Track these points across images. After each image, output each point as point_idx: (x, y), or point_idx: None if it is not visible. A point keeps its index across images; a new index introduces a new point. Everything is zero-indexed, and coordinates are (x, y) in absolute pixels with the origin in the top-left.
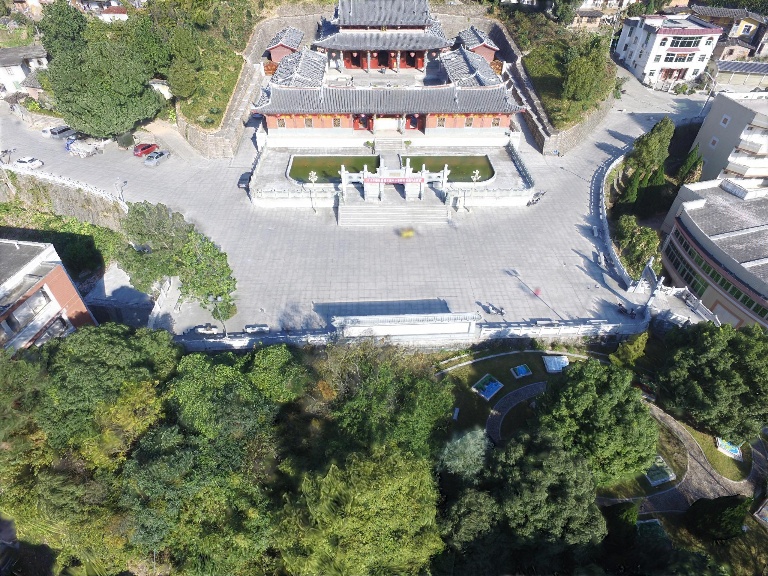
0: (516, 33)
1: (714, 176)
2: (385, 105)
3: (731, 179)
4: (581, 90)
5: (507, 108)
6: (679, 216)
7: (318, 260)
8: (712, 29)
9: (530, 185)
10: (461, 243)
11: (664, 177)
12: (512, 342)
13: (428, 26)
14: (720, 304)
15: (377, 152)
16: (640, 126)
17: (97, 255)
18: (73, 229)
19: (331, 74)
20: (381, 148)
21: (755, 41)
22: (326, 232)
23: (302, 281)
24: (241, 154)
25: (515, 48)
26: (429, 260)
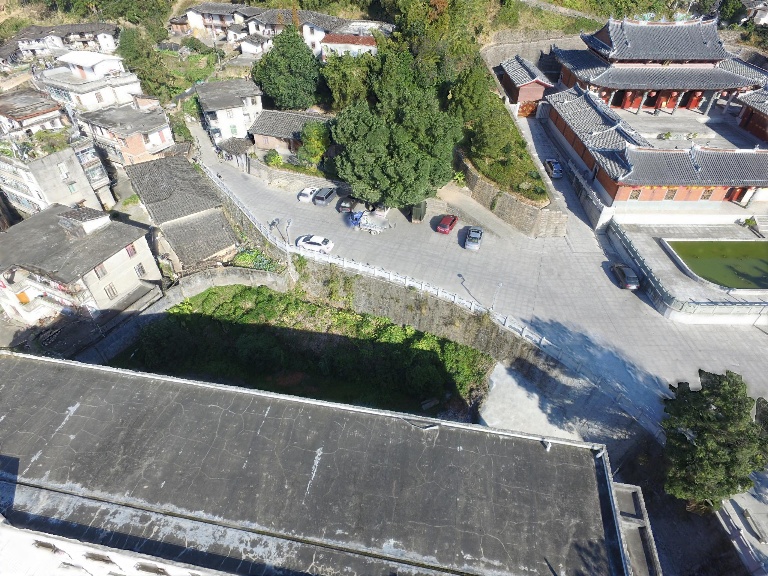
0: None
1: None
2: None
3: None
4: None
5: None
6: None
7: None
8: None
9: None
10: None
11: None
12: None
13: None
14: None
15: (766, 234)
16: None
17: (451, 381)
18: (395, 337)
19: None
20: (766, 228)
21: None
22: None
23: None
24: (573, 231)
25: None
26: None
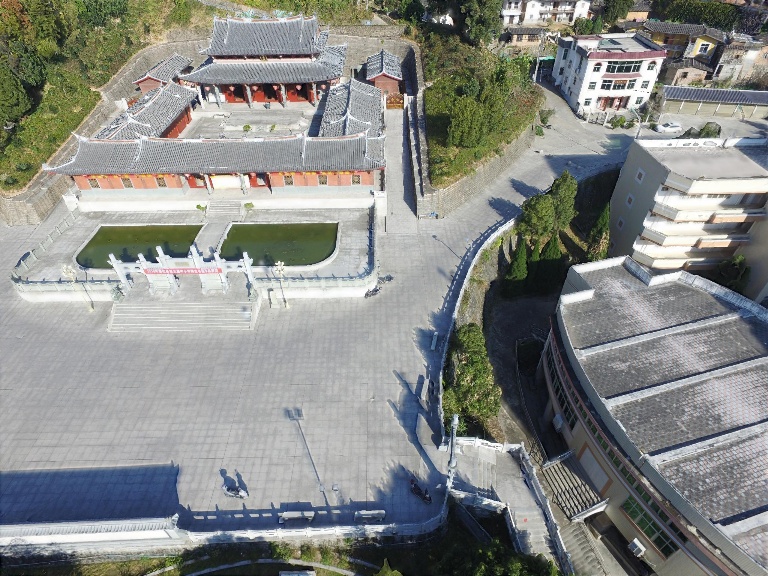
0: (426, 59)
1: (630, 242)
2: (214, 162)
3: (651, 246)
4: (468, 136)
5: (363, 165)
6: (556, 313)
7: (47, 391)
8: (653, 52)
9: (373, 268)
10: (251, 361)
11: (573, 240)
12: (243, 546)
13: (315, 54)
14: (589, 449)
15: (207, 219)
16: (553, 174)
17: None
18: None
19: (207, 110)
20: (214, 213)
21: (714, 61)
22: (86, 342)
23: (4, 429)
24: (51, 220)
25: (420, 78)
26: (194, 391)
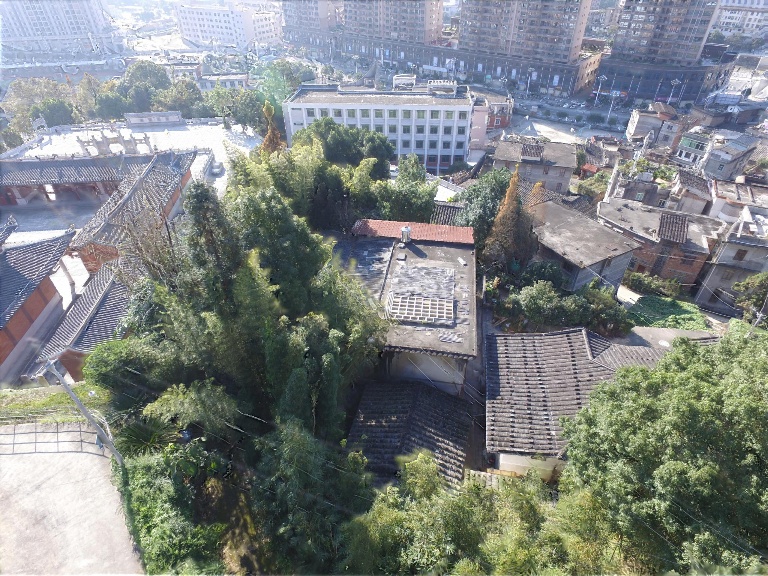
0: None
1: None
2: None
3: None
4: None
5: None
6: None
7: None
8: None
9: None
10: None
11: None
12: None
13: None
14: None
15: None
16: None
17: None
18: None
19: None
20: None
21: None
22: None
23: None
24: None
25: None
26: None
